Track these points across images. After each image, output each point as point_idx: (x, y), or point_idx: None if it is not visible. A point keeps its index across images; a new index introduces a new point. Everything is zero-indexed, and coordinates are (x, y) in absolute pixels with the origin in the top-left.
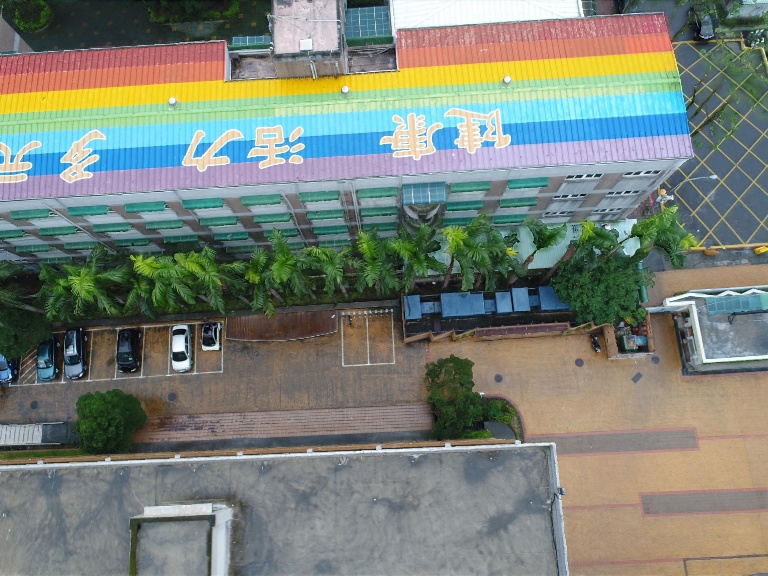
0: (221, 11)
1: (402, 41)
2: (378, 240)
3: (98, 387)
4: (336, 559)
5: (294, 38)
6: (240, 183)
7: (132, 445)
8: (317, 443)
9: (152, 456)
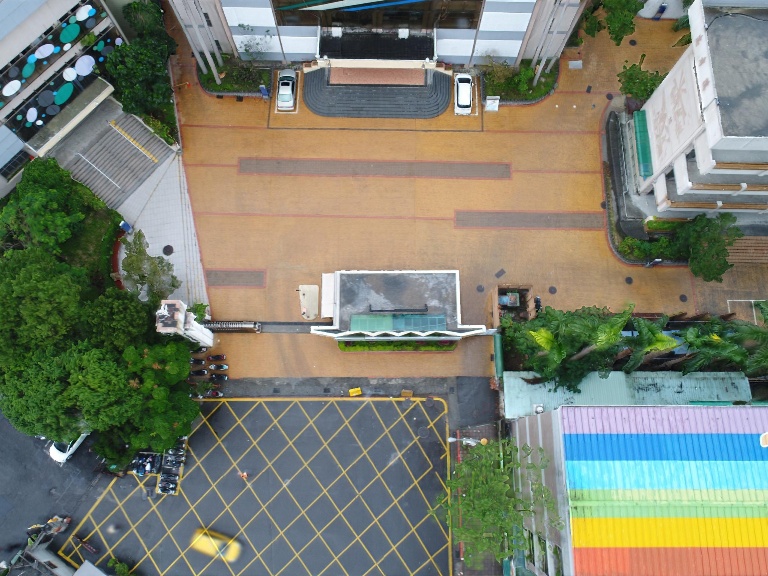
0: None
1: None
2: None
3: None
4: None
5: None
6: None
7: None
8: None
9: None
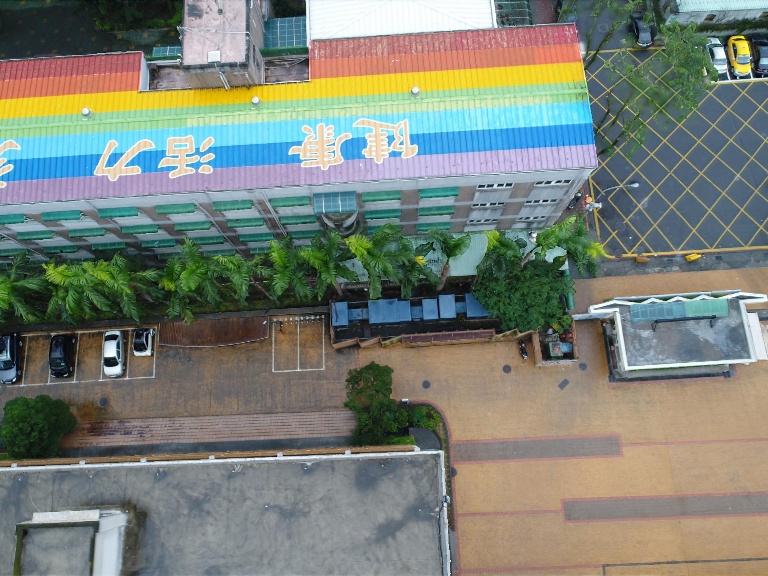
0: (166, 19)
1: (315, 52)
2: (290, 249)
3: (31, 392)
4: (225, 565)
5: (203, 50)
6: (150, 193)
7: (61, 449)
8: (243, 448)
9: (57, 462)
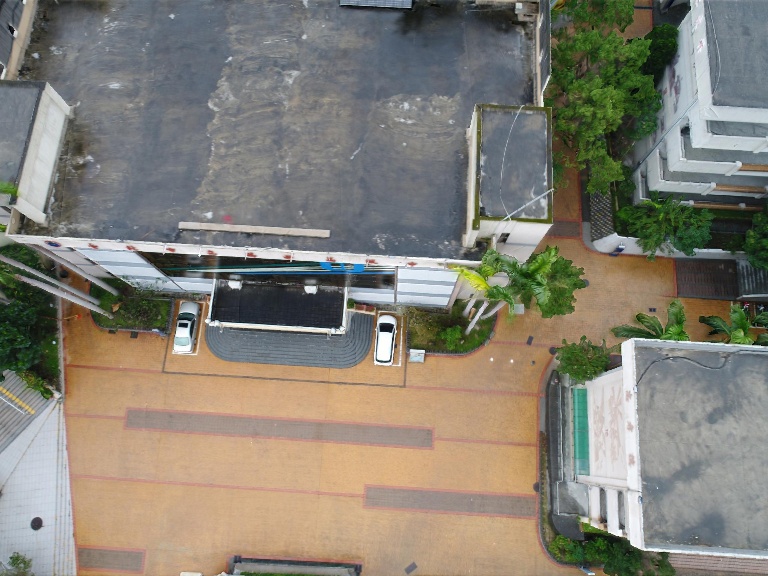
0: None
1: None
2: None
3: None
4: None
5: None
6: None
7: None
8: None
9: None
